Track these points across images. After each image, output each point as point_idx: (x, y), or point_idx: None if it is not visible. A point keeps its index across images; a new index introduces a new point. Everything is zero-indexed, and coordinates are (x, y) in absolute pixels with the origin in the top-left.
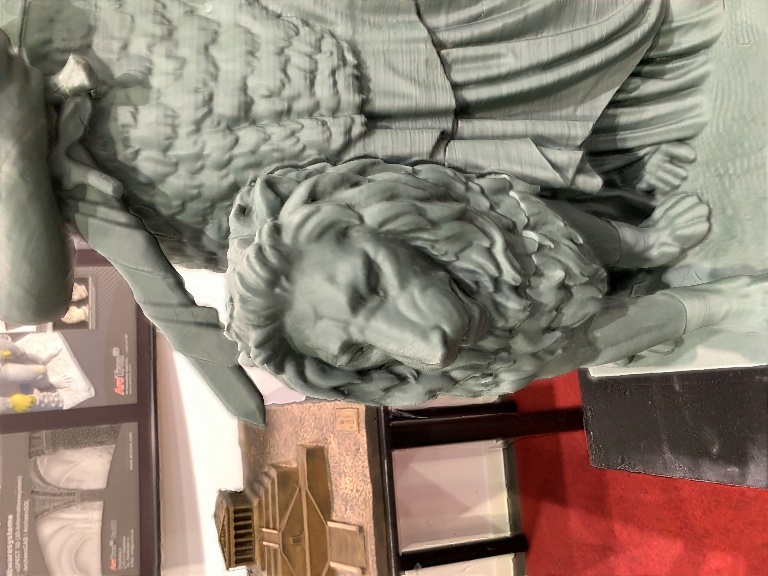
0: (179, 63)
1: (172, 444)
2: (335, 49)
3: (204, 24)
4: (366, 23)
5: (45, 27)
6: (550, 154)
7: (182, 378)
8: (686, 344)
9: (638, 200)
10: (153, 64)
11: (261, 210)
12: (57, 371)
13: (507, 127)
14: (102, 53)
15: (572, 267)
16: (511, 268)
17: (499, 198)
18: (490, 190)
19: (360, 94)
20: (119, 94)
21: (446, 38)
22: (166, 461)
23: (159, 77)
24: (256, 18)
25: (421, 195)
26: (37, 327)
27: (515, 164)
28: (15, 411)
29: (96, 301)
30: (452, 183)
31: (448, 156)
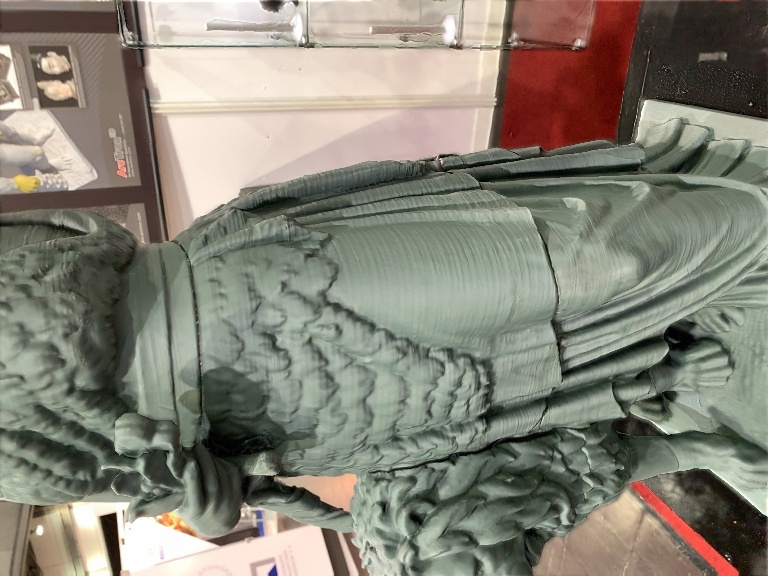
0: (342, 420)
1: (177, 219)
2: (474, 381)
3: (363, 379)
4: (503, 340)
5: (224, 401)
6: (623, 395)
7: (182, 159)
8: (670, 423)
9: (680, 328)
10: (319, 421)
11: (404, 534)
12: (55, 153)
13: (596, 375)
14: (276, 419)
15: (610, 492)
16: (569, 522)
17: (573, 456)
18: (568, 453)
19: (486, 405)
20: (290, 444)
21: (569, 329)
22: (173, 233)
23: (324, 431)
24: (410, 368)
25: (521, 509)
26: (22, 104)
27: (593, 415)
28: (21, 191)
29: (81, 75)
30: (542, 462)
31: (543, 424)
